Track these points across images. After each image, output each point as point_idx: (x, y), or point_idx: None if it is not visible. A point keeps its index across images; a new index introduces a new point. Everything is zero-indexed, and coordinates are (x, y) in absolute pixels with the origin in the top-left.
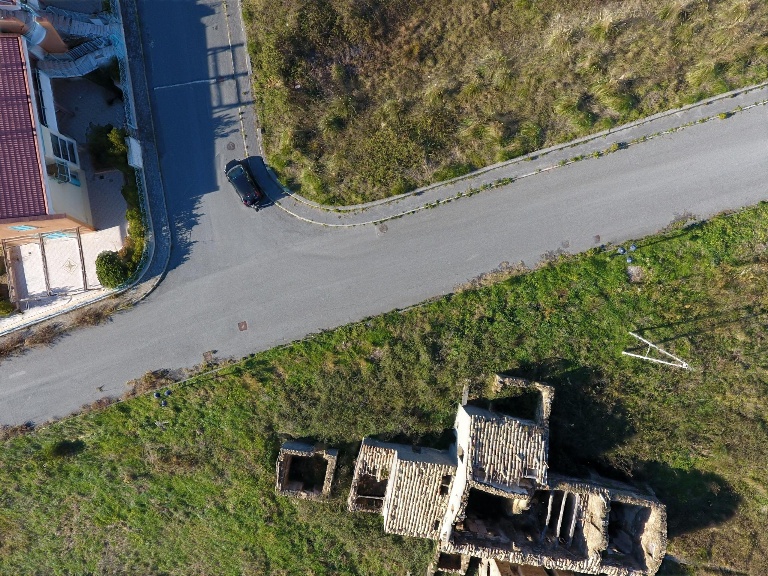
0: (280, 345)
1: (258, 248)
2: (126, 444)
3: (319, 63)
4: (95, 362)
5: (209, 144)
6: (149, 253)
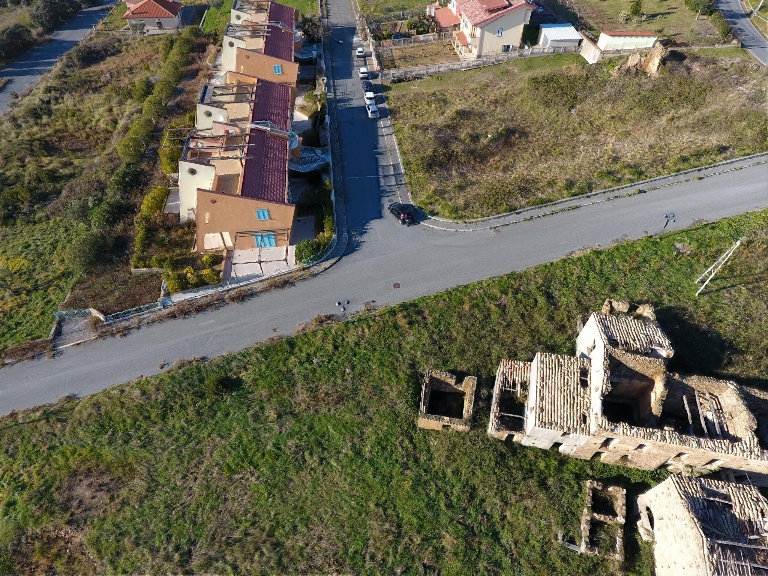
0: None
1: (409, 243)
2: (280, 382)
3: (445, 169)
4: (275, 312)
5: (377, 200)
6: (333, 244)
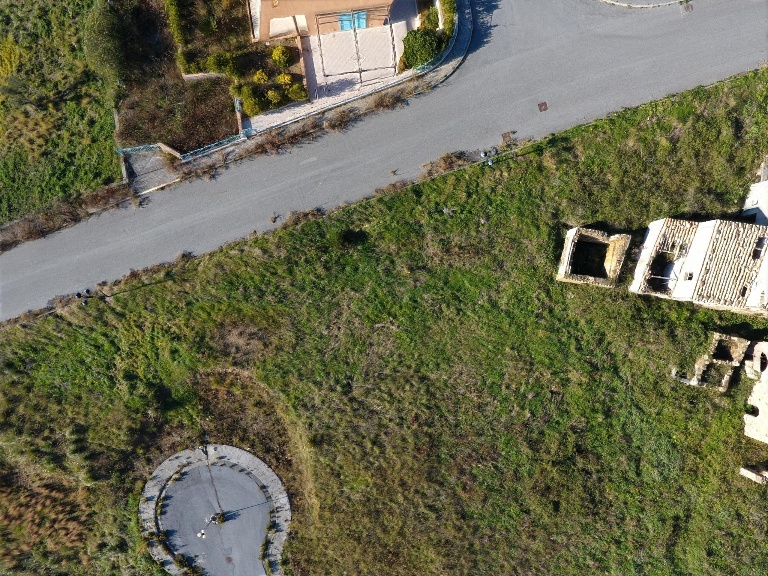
0: (581, 124)
1: (560, 31)
2: (408, 235)
3: None
4: (390, 146)
5: None
6: (454, 33)
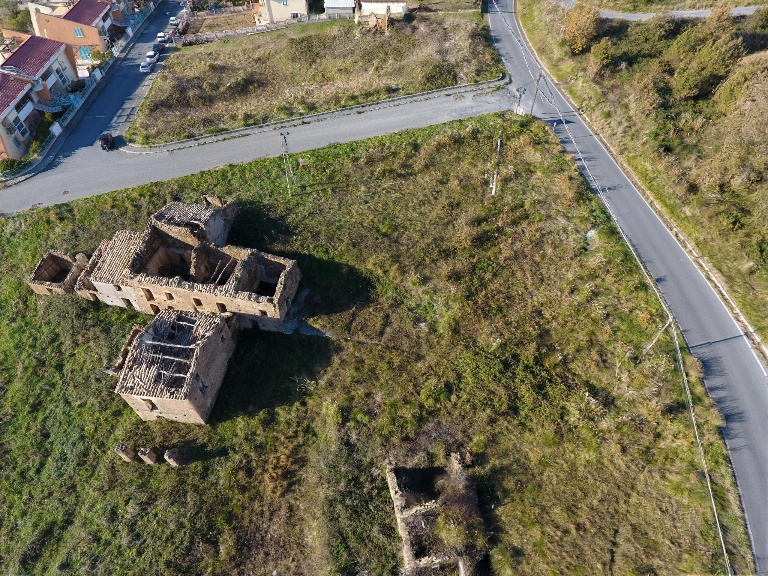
0: None
1: (98, 163)
2: None
3: (172, 110)
4: None
5: None
6: (34, 163)
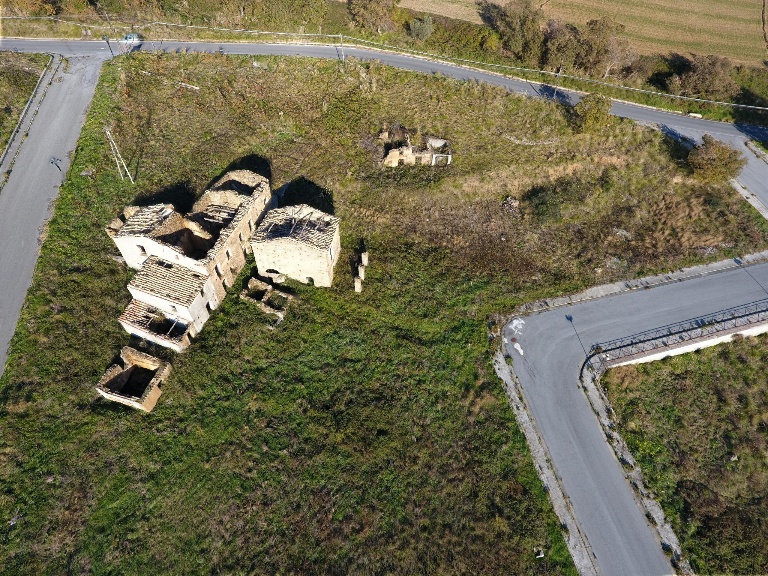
0: (1, 376)
1: None
2: (19, 575)
3: None
4: None
5: None
6: None
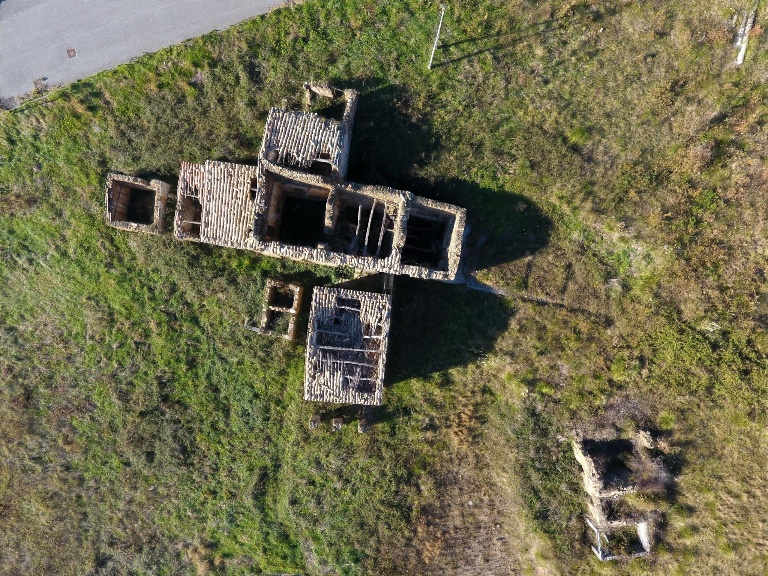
0: (106, 70)
1: None
2: None
3: None
4: None
5: None
6: None
